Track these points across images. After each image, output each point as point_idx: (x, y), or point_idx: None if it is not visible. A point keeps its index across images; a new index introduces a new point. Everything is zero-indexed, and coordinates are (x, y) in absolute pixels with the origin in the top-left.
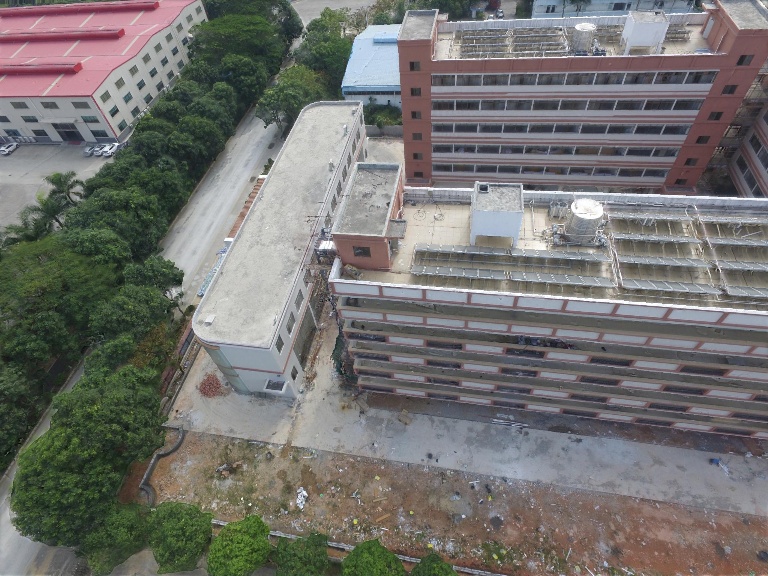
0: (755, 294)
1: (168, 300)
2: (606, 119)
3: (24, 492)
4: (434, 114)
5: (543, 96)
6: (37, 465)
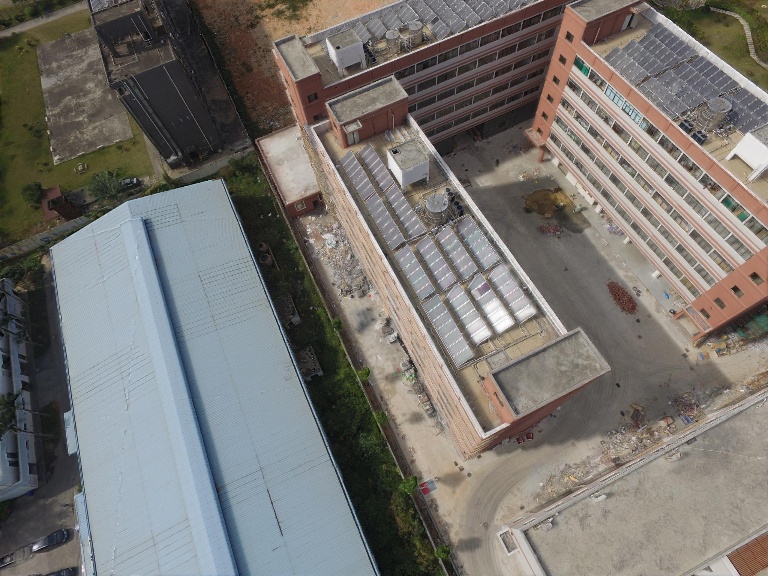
0: (689, 47)
1: None
2: None
3: None
4: None
5: None
6: None
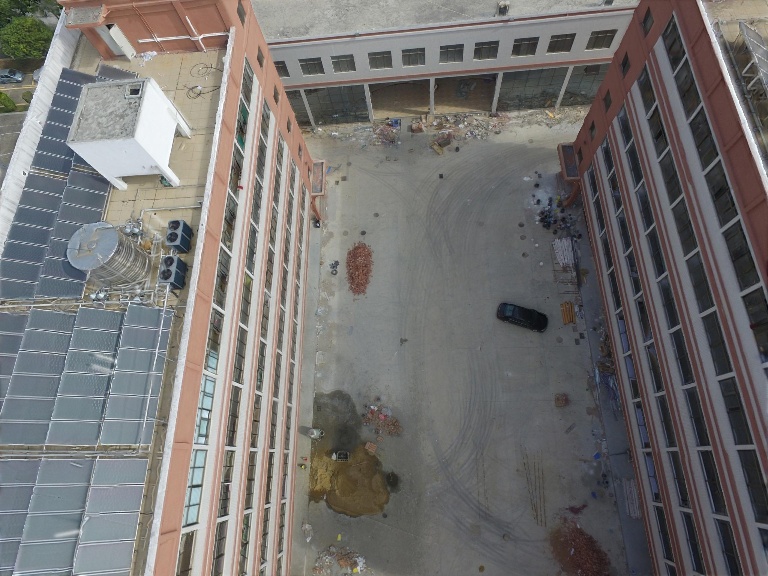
0: None
1: None
2: (717, 436)
3: None
4: (634, 91)
5: (709, 262)
6: None
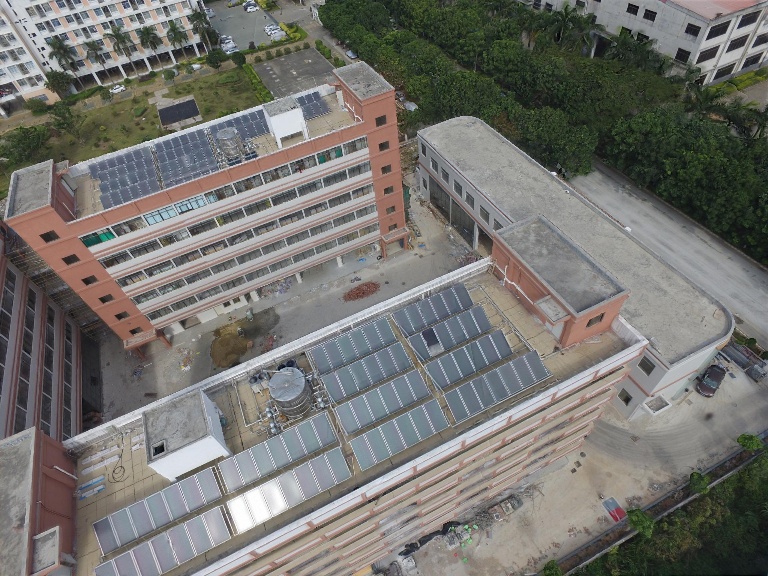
0: (137, 150)
1: (530, 136)
2: None
3: (462, 72)
4: None
5: None
6: None
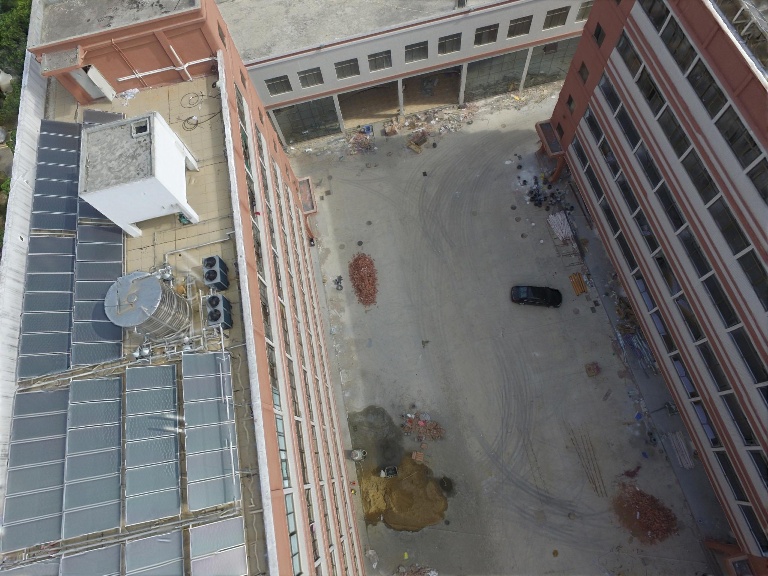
0: None
1: None
2: None
3: (8, 13)
4: (614, 57)
5: (736, 204)
6: (21, 4)
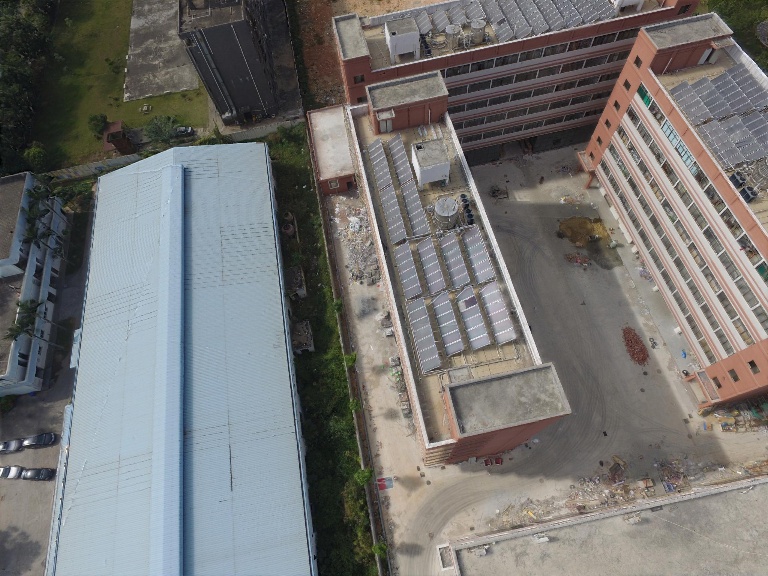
0: (767, 95)
1: None
2: None
3: None
4: None
5: None
6: None
